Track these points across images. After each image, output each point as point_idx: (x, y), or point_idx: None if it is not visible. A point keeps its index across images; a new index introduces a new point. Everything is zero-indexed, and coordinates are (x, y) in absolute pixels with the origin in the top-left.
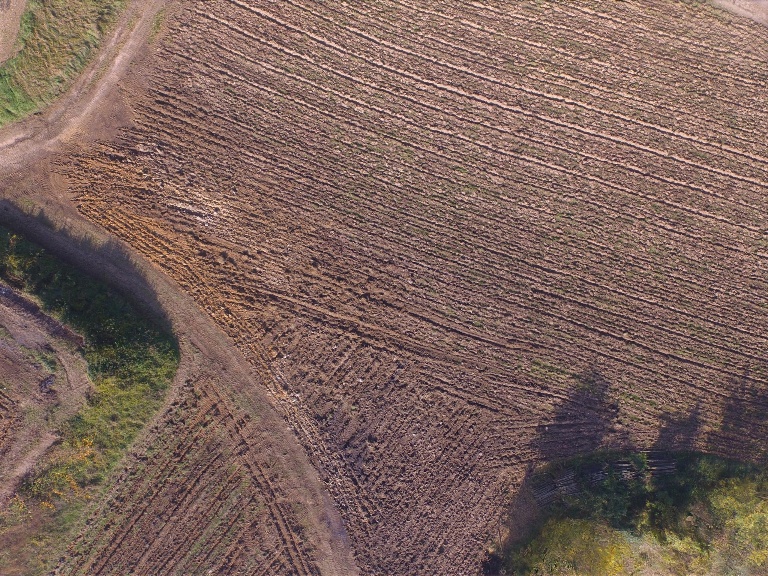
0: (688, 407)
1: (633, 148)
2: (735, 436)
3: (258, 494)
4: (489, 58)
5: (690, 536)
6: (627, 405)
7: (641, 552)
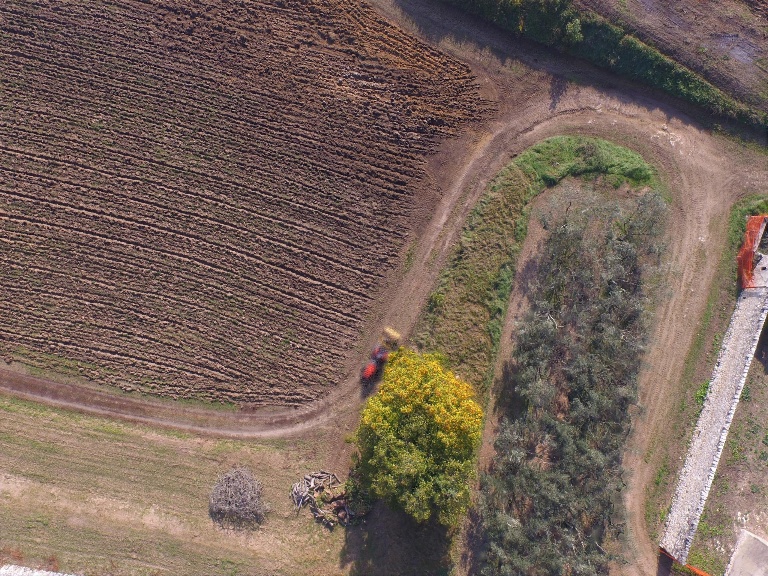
0: None
1: None
2: None
3: None
4: (85, 253)
5: None
6: None
7: None
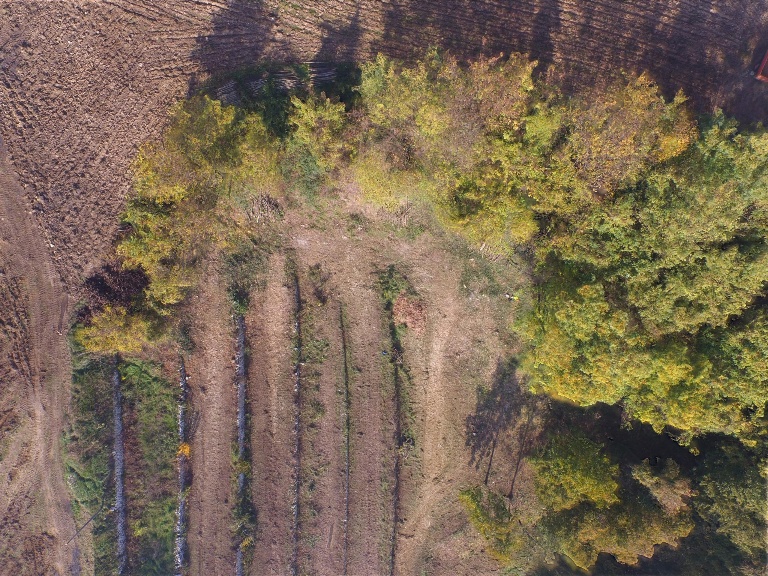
0: (348, 15)
1: None
2: (398, 45)
3: None
4: None
5: (314, 101)
6: (287, 14)
7: (352, 213)
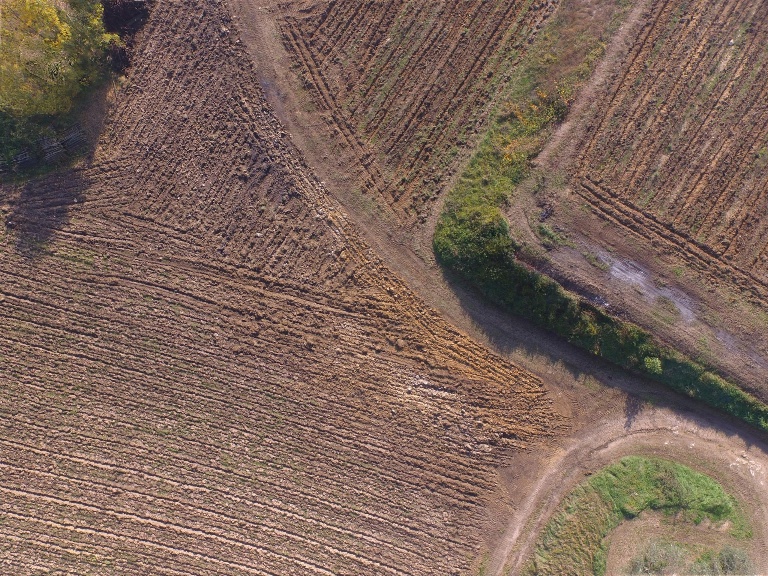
0: None
1: (3, 485)
2: None
3: (348, 117)
4: (152, 564)
5: None
6: None
7: None
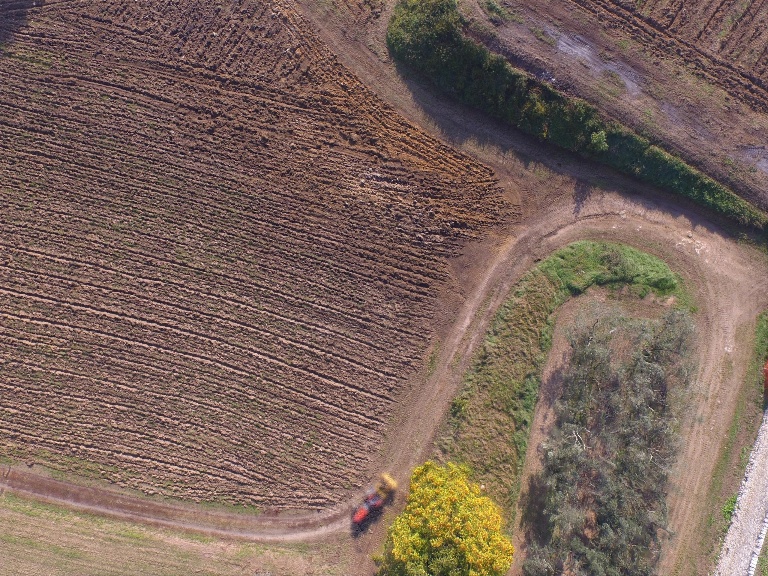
0: None
1: None
2: None
3: None
4: (107, 355)
5: None
6: None
7: None
